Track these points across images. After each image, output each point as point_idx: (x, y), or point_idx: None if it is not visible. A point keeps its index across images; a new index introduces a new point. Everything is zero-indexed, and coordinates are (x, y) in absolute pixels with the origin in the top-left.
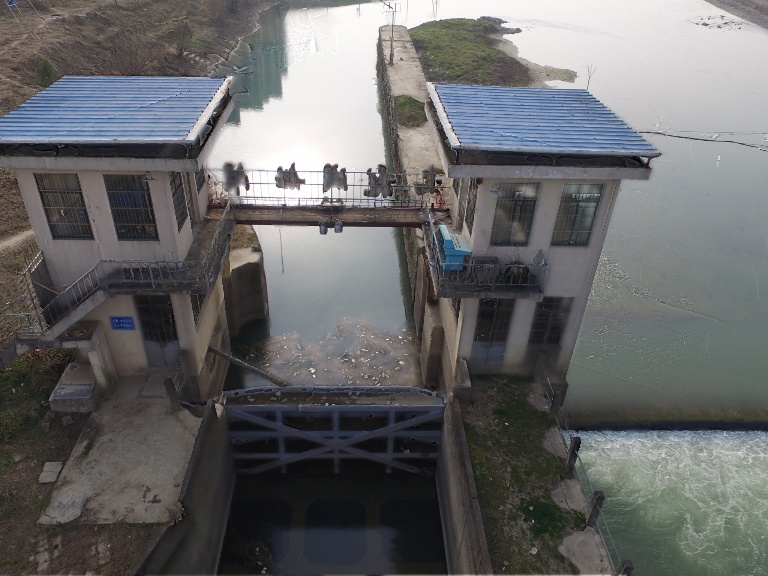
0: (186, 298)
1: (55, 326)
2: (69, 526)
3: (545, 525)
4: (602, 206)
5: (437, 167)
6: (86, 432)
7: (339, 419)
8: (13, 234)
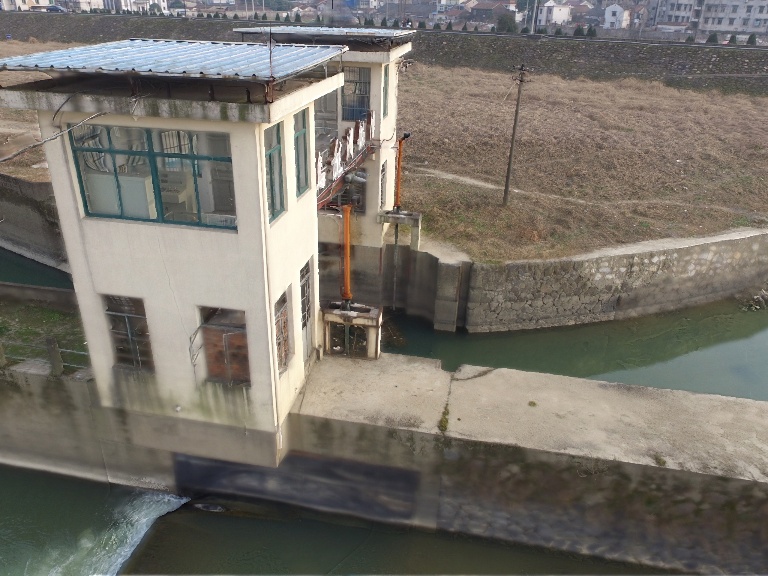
0: None
1: None
2: None
3: None
4: None
5: None
6: None
7: None
8: (486, 182)
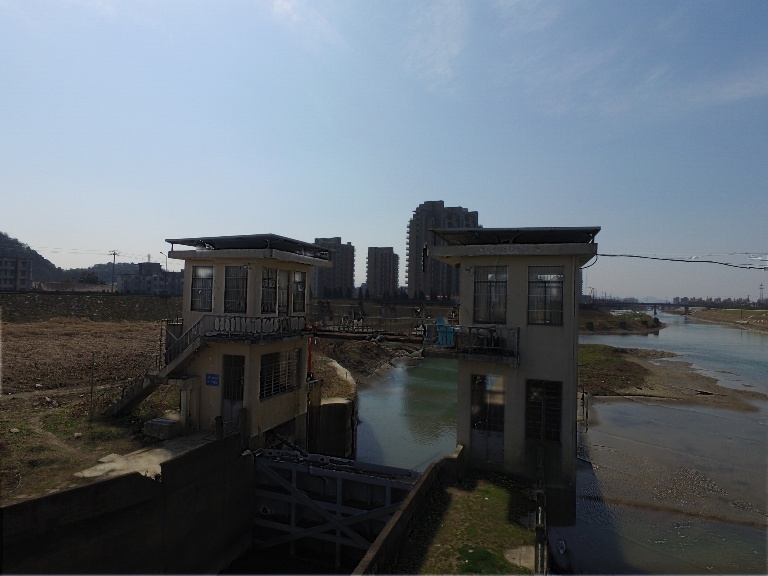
0: (255, 363)
1: (168, 365)
2: (87, 479)
3: (479, 567)
4: (567, 286)
5: None
6: (151, 446)
7: (342, 489)
8: None
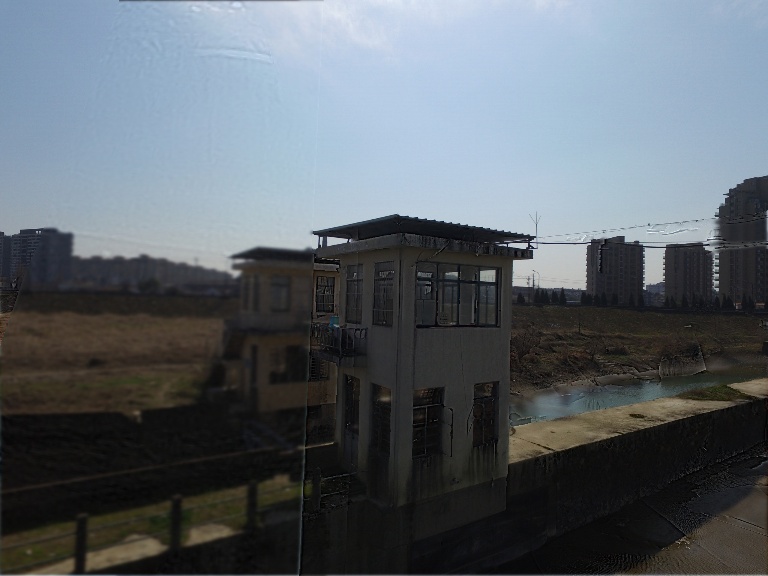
0: None
1: None
2: None
3: None
4: None
5: (644, 414)
6: None
7: None
8: None
